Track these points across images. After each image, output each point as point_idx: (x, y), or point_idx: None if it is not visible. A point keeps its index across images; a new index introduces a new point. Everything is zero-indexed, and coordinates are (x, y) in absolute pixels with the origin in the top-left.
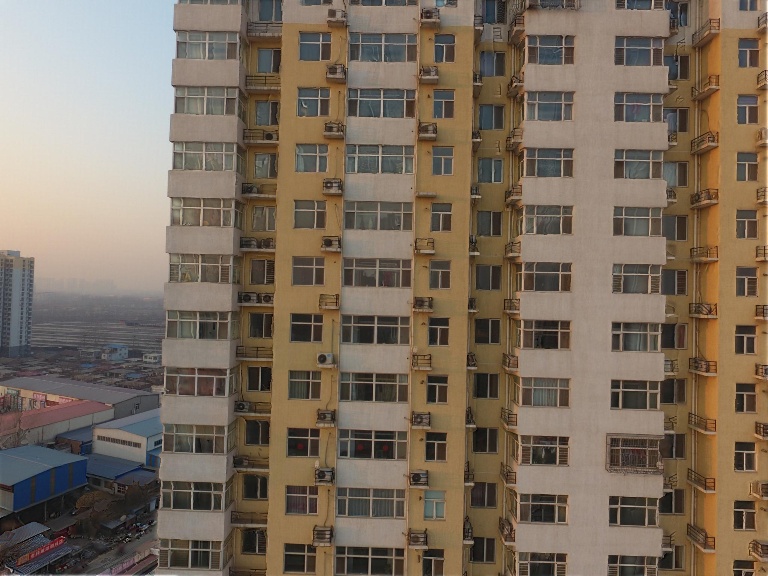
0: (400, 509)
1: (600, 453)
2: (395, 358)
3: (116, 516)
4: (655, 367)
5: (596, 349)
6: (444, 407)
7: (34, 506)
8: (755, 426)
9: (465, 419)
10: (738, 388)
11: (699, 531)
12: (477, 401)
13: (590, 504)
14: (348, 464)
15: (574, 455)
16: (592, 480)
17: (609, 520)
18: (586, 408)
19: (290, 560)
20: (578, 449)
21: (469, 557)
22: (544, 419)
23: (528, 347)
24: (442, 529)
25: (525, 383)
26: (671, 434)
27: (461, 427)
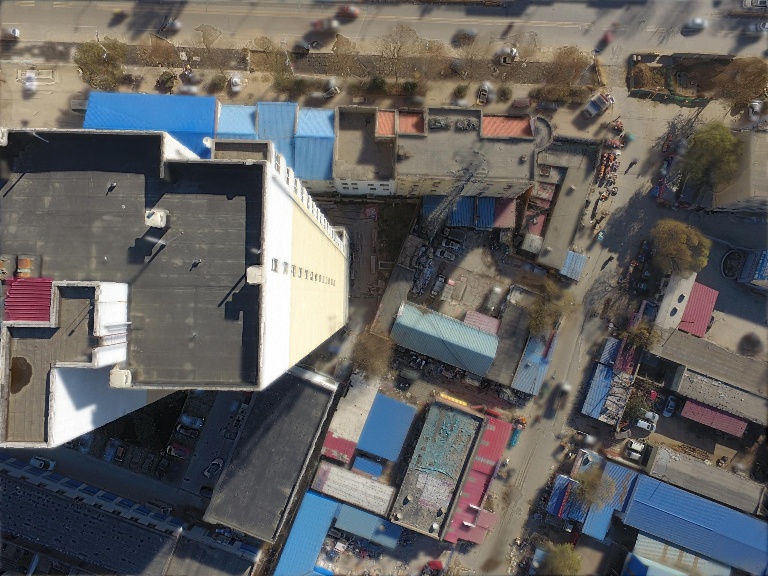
0: None
1: None
2: None
3: (545, 568)
4: None
5: None
6: None
7: (624, 567)
8: None
9: None
10: None
11: None
12: None
13: None
14: None
15: None
16: None
17: None
18: None
19: None
20: None
21: None
22: None
23: None
24: None
25: None
26: None
27: None
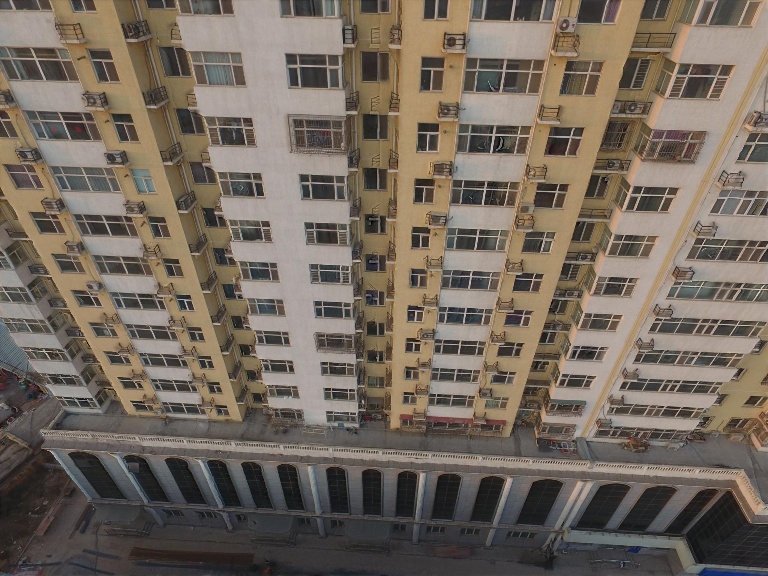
0: (117, 185)
1: (284, 134)
2: (43, 28)
3: None
4: (332, 37)
5: (262, 14)
6: (117, 87)
7: None
8: (438, 106)
9: (143, 100)
10: (425, 63)
11: (391, 204)
12: (169, 80)
13: (282, 181)
14: (49, 145)
15: (260, 136)
16: (280, 160)
17: (303, 195)
18: (263, 87)
19: (41, 224)
20: (262, 130)
21: (205, 223)
22: (222, 99)
23: (187, 12)
24: (156, 201)
25: (194, 58)
26: (353, 115)
27: (141, 108)
